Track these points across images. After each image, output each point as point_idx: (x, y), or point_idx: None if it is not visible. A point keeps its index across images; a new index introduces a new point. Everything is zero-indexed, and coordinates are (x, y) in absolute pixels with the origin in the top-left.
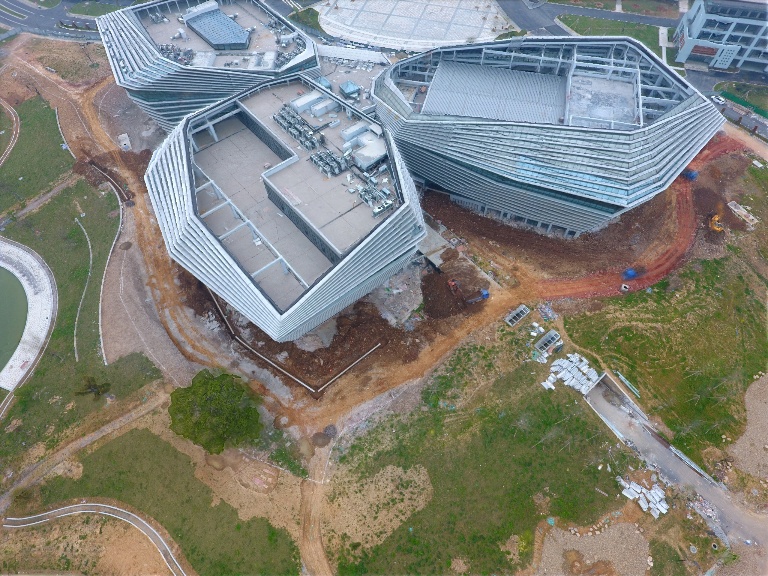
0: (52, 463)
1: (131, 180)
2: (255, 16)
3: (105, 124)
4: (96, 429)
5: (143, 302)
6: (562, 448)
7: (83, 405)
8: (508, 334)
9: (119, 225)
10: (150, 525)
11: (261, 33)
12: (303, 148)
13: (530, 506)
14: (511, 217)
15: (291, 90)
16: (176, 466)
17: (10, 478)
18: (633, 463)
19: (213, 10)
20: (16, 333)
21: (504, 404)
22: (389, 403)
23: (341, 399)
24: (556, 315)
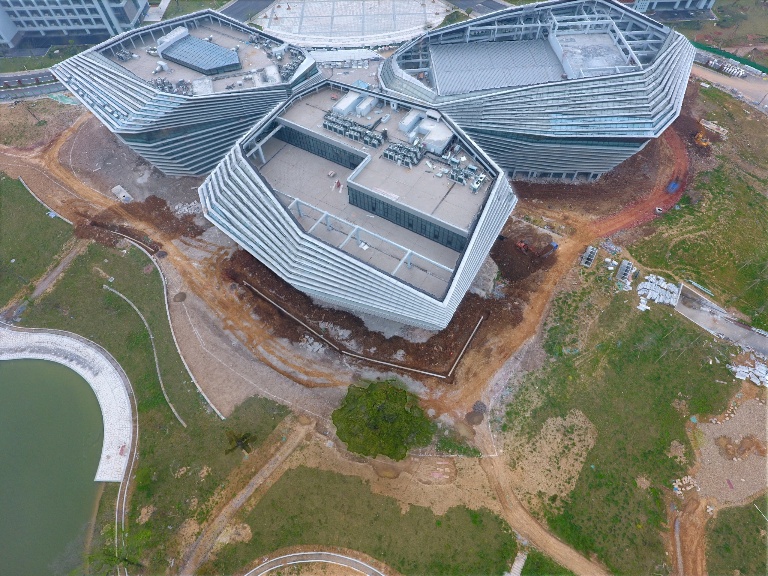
0: (213, 535)
1: (150, 231)
2: (230, 35)
3: (88, 181)
4: (245, 485)
5: (231, 346)
6: (679, 355)
7: (219, 466)
8: (590, 275)
9: (161, 278)
10: (346, 556)
11: (246, 51)
12: (369, 147)
13: (673, 413)
14: (537, 175)
15: (322, 97)
16: (349, 490)
17: (173, 567)
18: (733, 350)
19: (184, 37)
20: (94, 421)
21: (616, 334)
22: (519, 365)
23: (474, 376)
24: (619, 248)
